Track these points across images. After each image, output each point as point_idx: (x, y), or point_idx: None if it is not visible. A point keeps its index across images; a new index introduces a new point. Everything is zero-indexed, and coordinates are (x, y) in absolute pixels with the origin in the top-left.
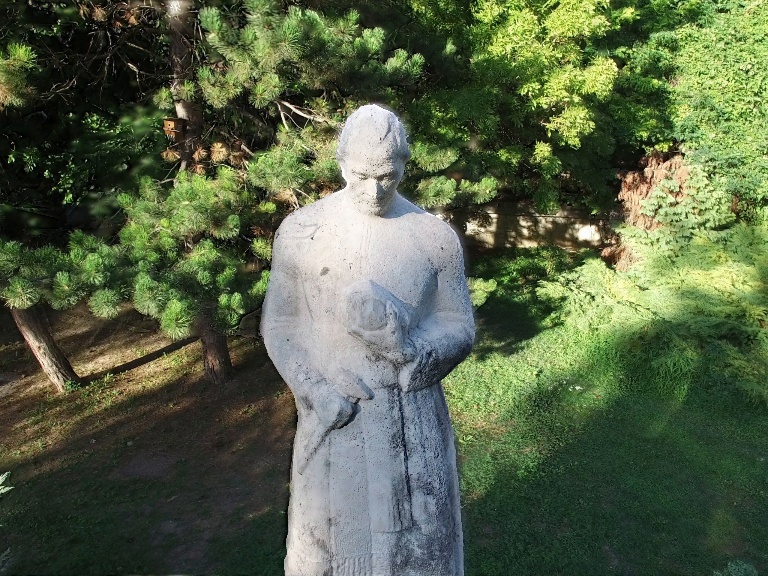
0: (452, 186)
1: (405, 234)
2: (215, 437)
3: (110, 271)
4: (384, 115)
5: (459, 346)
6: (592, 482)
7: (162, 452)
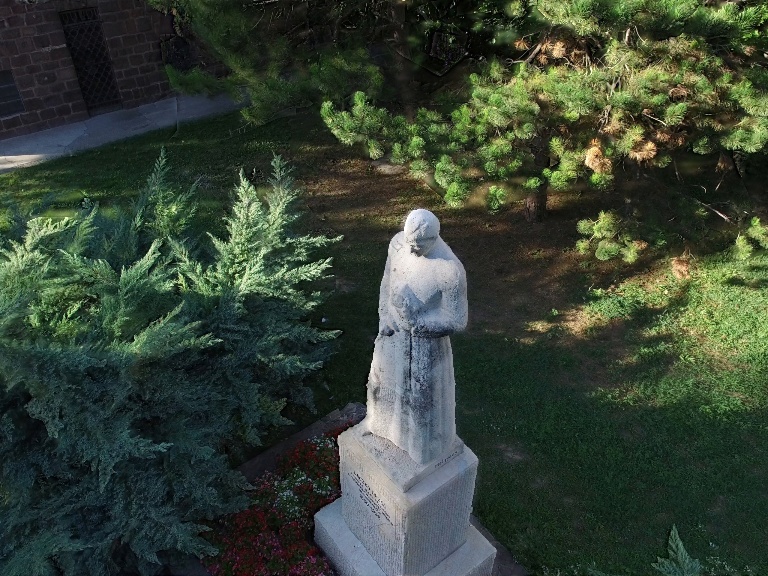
0: (760, 138)
1: (431, 269)
2: (501, 264)
3: (431, 146)
4: (419, 221)
5: (443, 329)
6: (764, 449)
7: (463, 259)
